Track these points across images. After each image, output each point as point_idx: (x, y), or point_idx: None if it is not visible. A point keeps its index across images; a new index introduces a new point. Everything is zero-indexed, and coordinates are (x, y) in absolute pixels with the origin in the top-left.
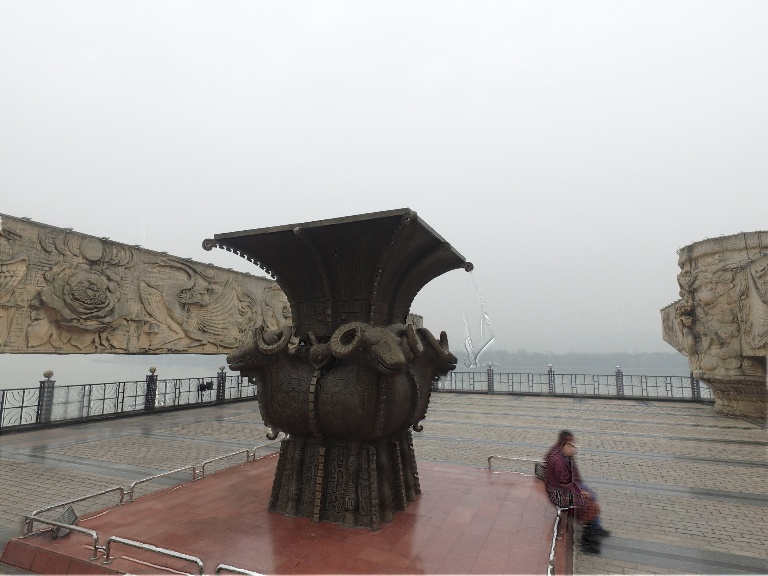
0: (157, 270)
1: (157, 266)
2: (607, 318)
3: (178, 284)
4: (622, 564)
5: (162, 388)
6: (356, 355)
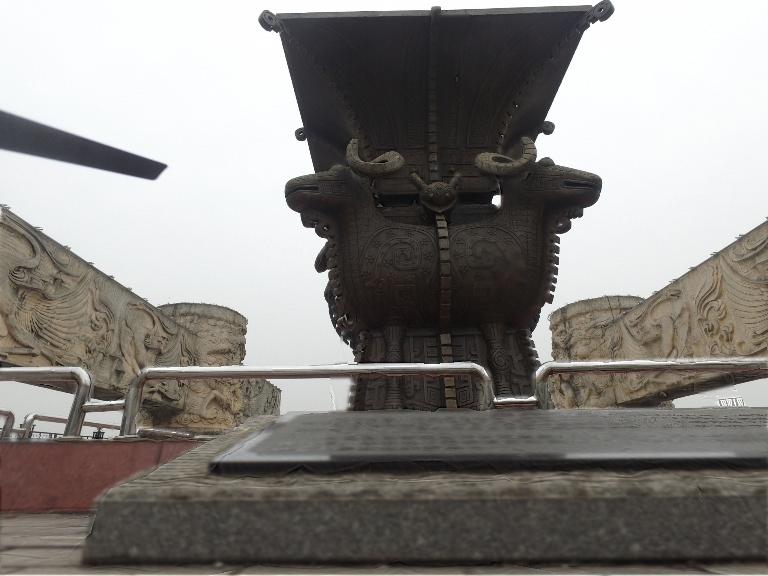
0: None
1: None
2: None
3: (15, 256)
4: None
5: None
6: (479, 213)
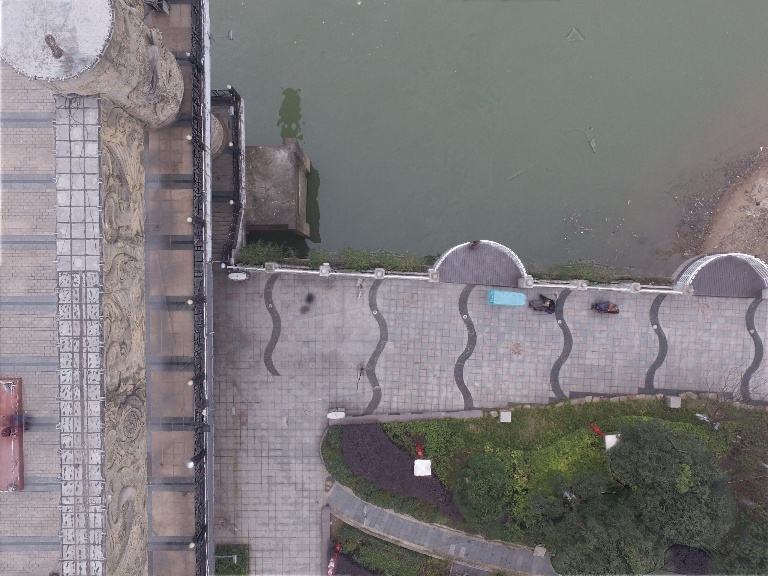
0: None
1: None
2: None
3: None
4: (33, 433)
5: None
6: None
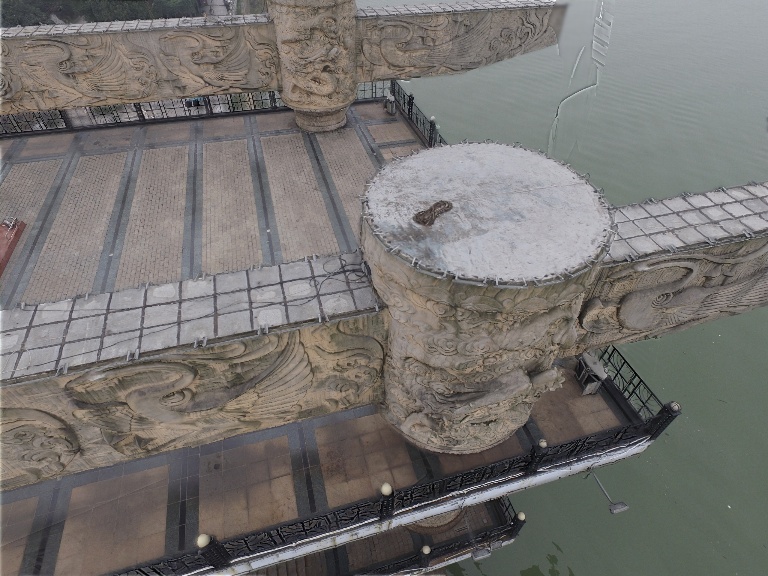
0: (31, 50)
1: (28, 48)
2: (751, 129)
3: (54, 59)
4: None
5: (147, 106)
6: None
